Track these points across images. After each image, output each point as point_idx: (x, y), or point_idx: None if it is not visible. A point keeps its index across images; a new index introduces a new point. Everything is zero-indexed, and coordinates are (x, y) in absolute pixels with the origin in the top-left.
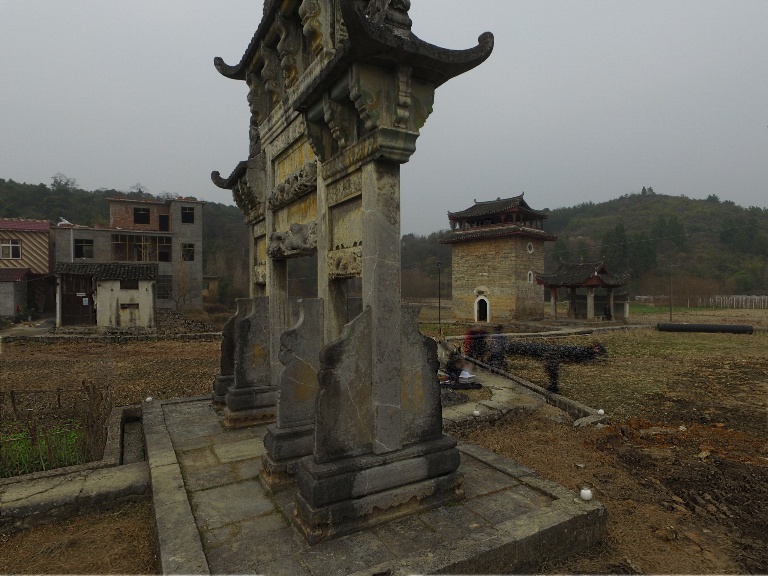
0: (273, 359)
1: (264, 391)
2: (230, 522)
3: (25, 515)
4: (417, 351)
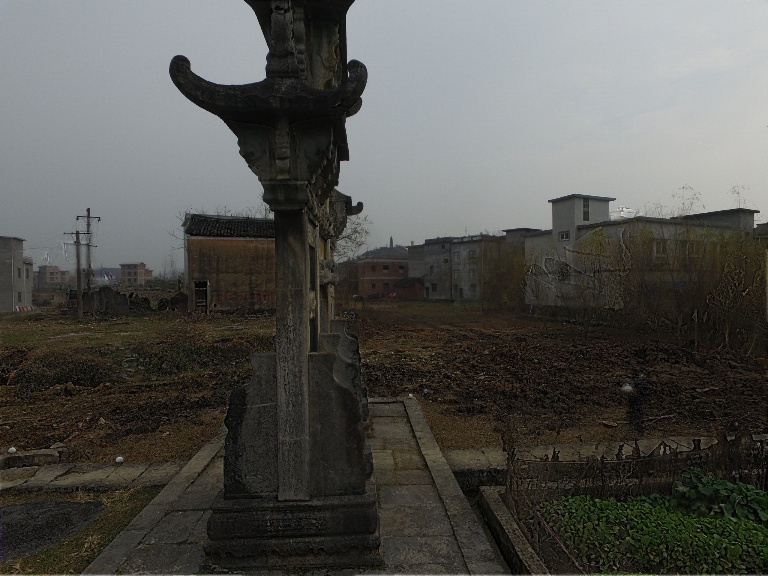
0: None
1: None
2: None
3: None
4: None
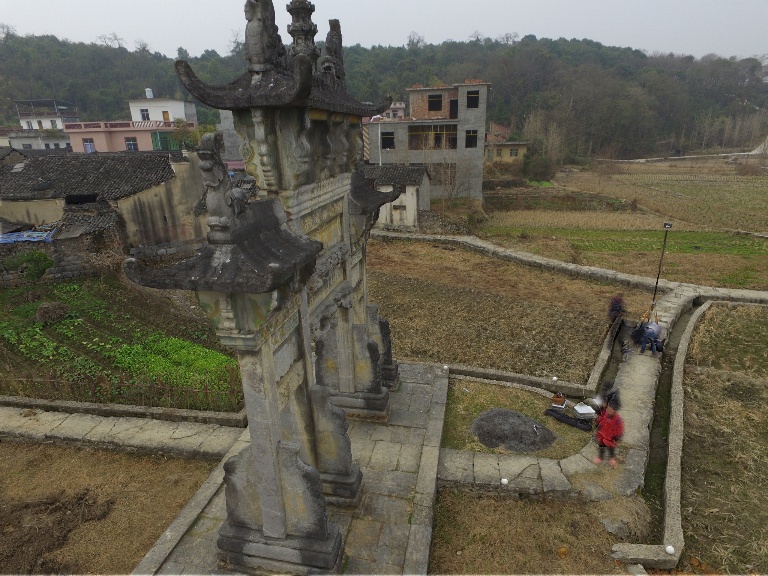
0: (340, 373)
1: (334, 395)
2: (217, 518)
3: (173, 451)
4: (297, 479)
